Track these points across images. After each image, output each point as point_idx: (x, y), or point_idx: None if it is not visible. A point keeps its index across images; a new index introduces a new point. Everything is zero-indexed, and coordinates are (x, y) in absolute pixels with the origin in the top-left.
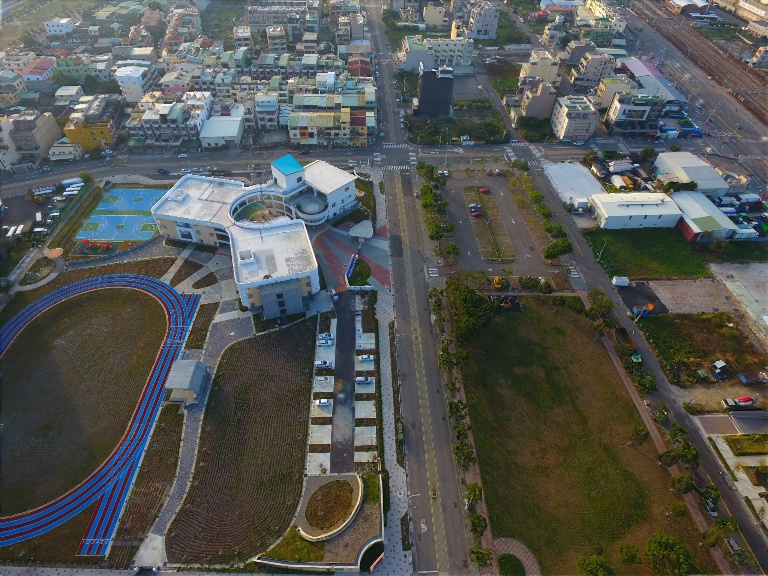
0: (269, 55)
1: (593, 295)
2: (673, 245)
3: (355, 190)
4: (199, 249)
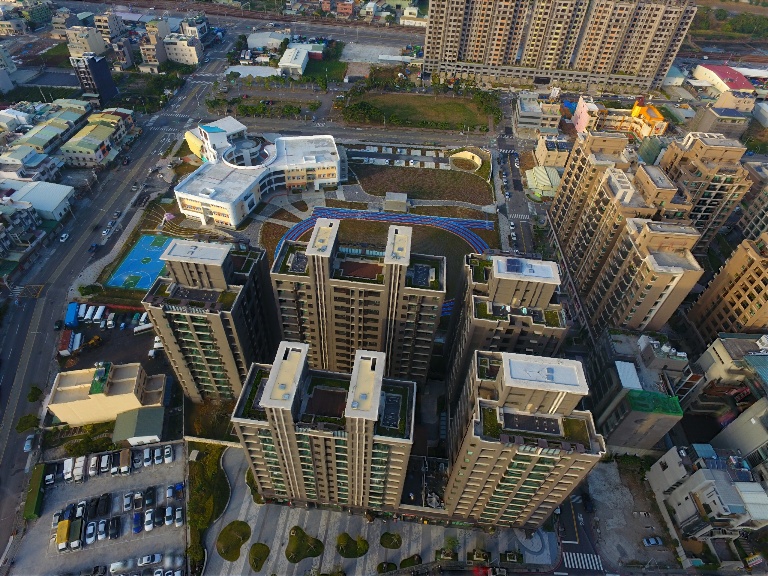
0: None
1: (359, 83)
2: (322, 64)
3: None
4: (259, 211)
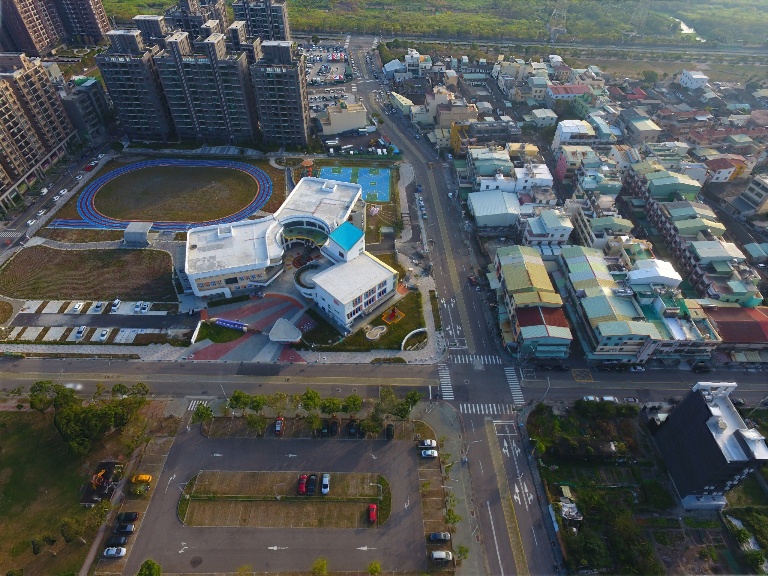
0: (695, 208)
1: None
2: None
3: (381, 330)
4: None
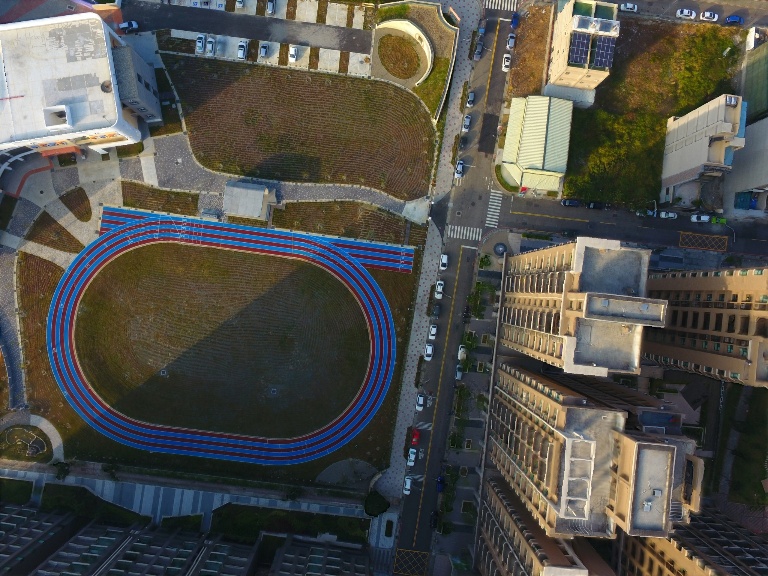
0: None
1: None
2: None
3: None
4: (4, 222)
